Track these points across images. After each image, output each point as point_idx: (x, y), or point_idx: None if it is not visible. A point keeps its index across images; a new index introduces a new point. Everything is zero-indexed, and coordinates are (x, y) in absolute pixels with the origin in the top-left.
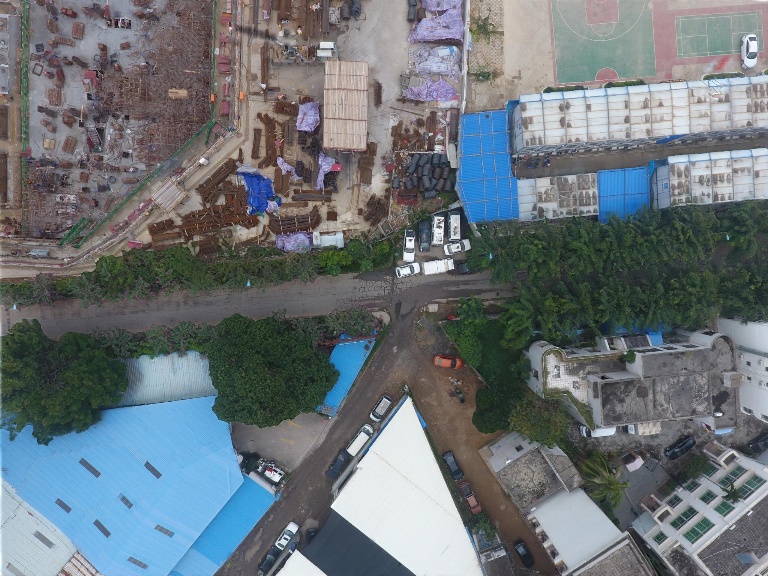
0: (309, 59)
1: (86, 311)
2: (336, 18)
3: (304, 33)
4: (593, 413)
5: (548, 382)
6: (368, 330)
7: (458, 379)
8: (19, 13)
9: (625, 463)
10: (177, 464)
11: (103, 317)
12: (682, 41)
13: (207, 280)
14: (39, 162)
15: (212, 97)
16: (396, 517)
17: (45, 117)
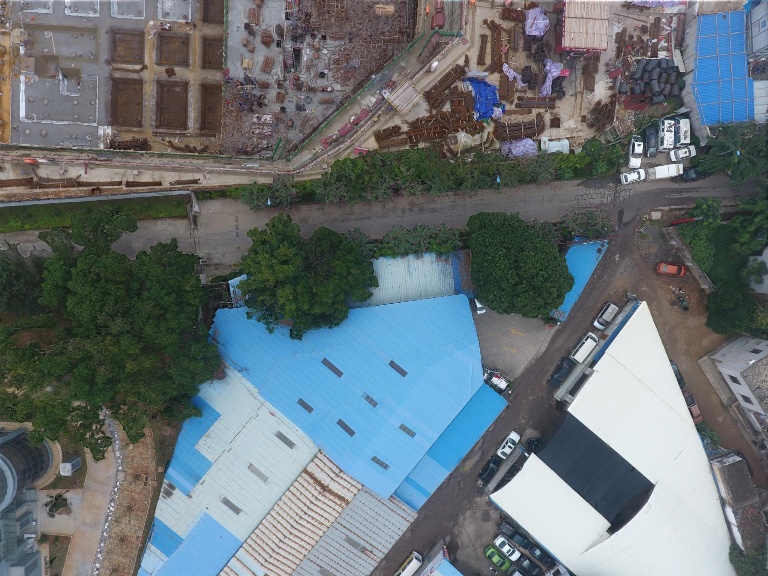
0: None
1: (313, 217)
2: None
3: None
4: None
5: None
6: (607, 231)
7: (680, 288)
8: None
9: None
10: (424, 362)
11: (330, 224)
12: None
13: None
14: None
15: (428, 8)
16: (631, 421)
17: (247, 35)
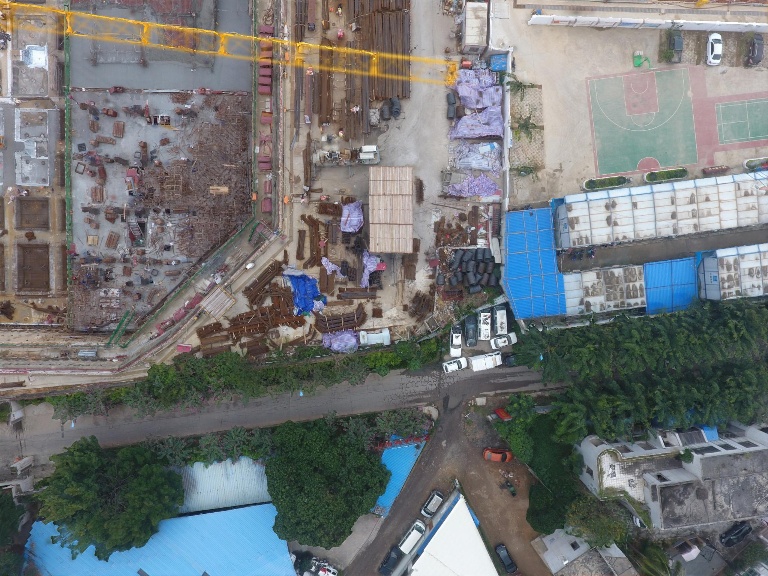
0: (351, 161)
1: None
2: (376, 119)
3: (345, 134)
4: (651, 513)
5: (604, 482)
6: (419, 432)
7: (508, 471)
8: (58, 107)
9: (681, 553)
10: (235, 574)
11: (154, 421)
12: (723, 128)
13: (260, 391)
14: (84, 260)
15: (254, 196)
16: None
17: (89, 216)
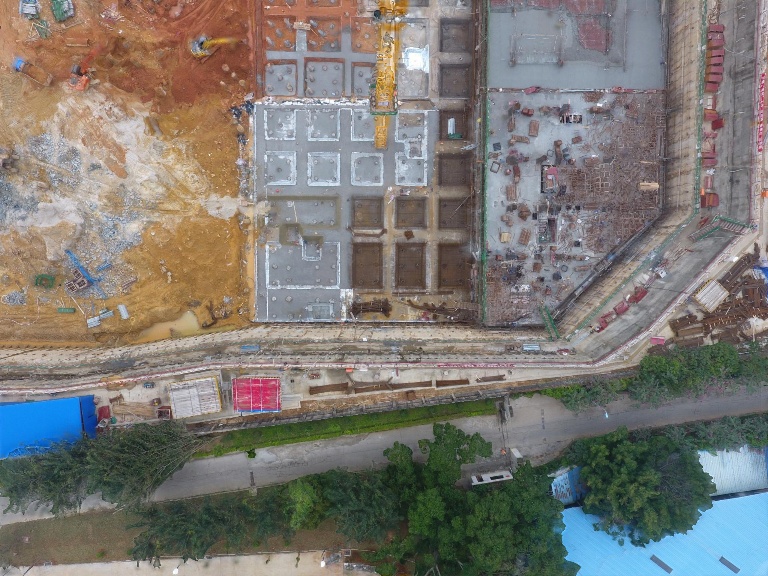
0: None
1: (615, 407)
2: None
3: None
4: None
5: None
6: None
7: None
8: (438, 108)
9: None
10: (756, 559)
11: (631, 412)
12: None
13: None
14: None
15: (703, 191)
16: None
17: (510, 213)
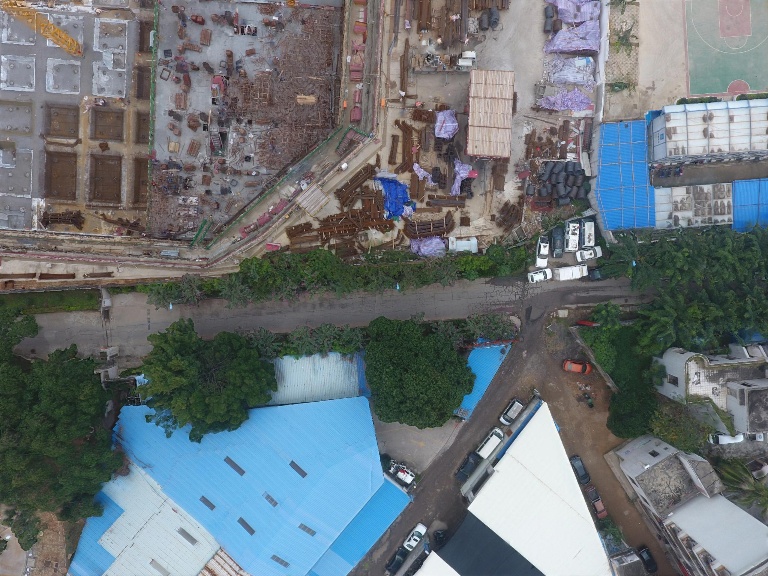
0: (449, 68)
1: (224, 311)
2: (475, 28)
3: (443, 42)
4: (735, 420)
5: (689, 388)
6: (508, 334)
7: (586, 384)
8: (138, 19)
9: (751, 470)
10: (323, 464)
11: (241, 318)
12: None
13: (357, 283)
14: None
15: (345, 103)
16: (530, 520)
17: (173, 121)
